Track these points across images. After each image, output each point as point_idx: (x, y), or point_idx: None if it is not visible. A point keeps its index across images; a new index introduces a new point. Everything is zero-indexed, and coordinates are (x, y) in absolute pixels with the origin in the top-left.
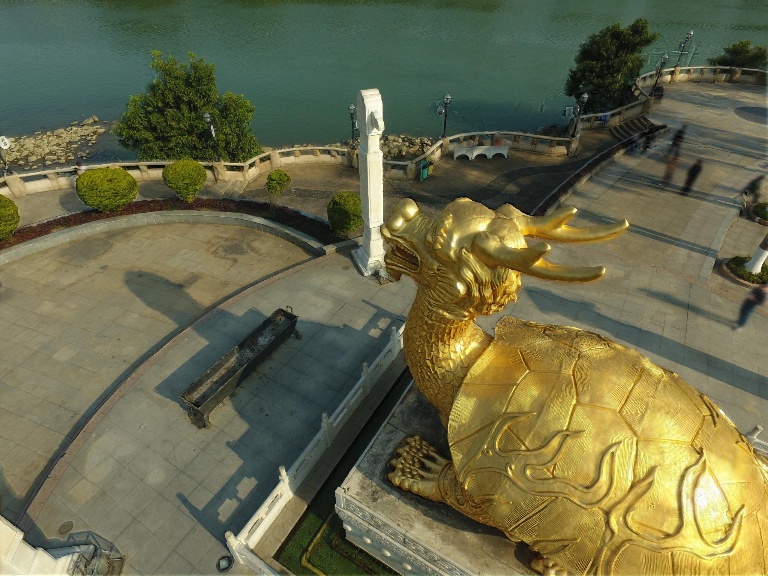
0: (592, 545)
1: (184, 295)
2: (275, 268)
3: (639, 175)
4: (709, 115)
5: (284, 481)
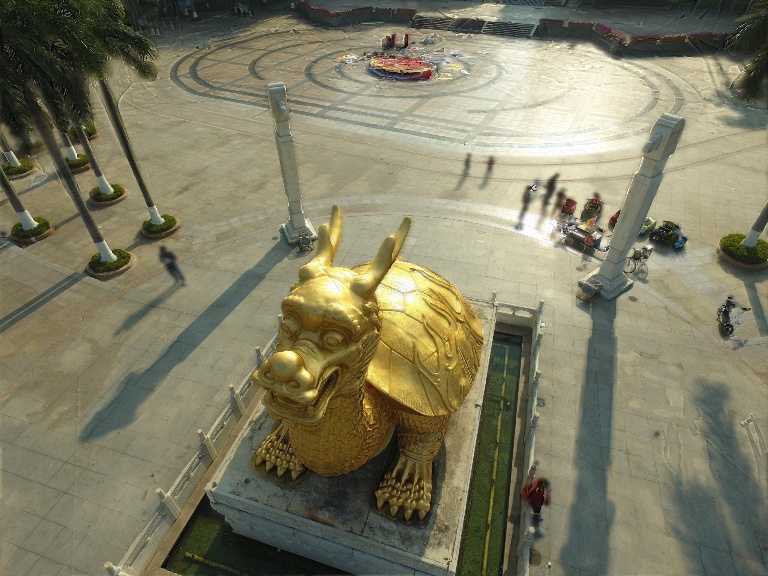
0: None
1: None
2: None
3: None
4: None
5: None
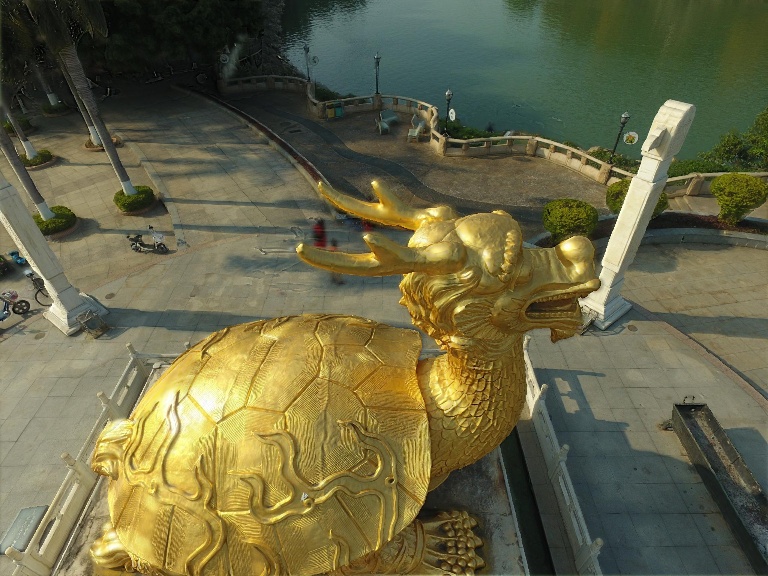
0: None
1: None
2: None
3: None
4: None
5: None
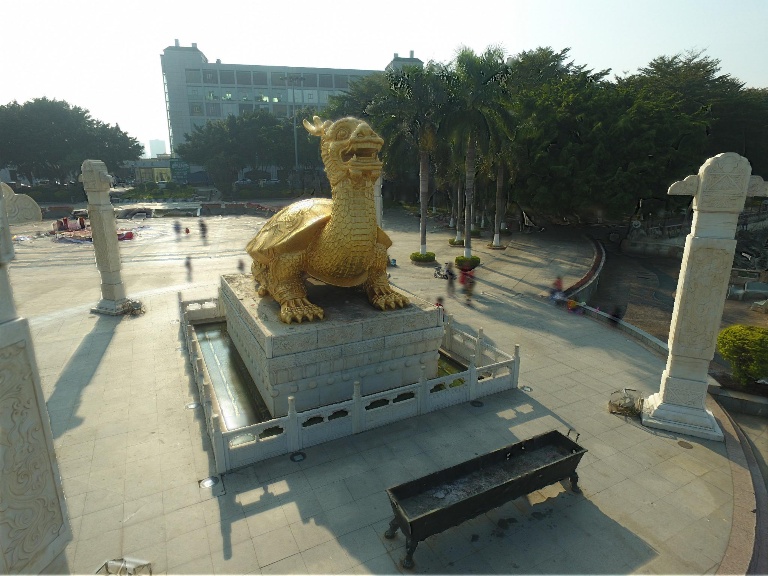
0: None
1: None
2: None
3: None
4: None
5: None
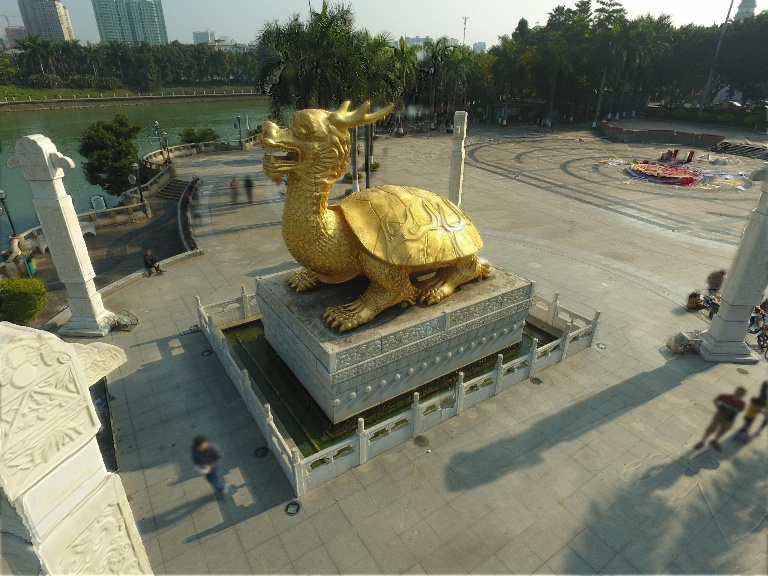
0: (449, 242)
1: None
2: None
3: (218, 205)
4: (213, 169)
5: (272, 419)
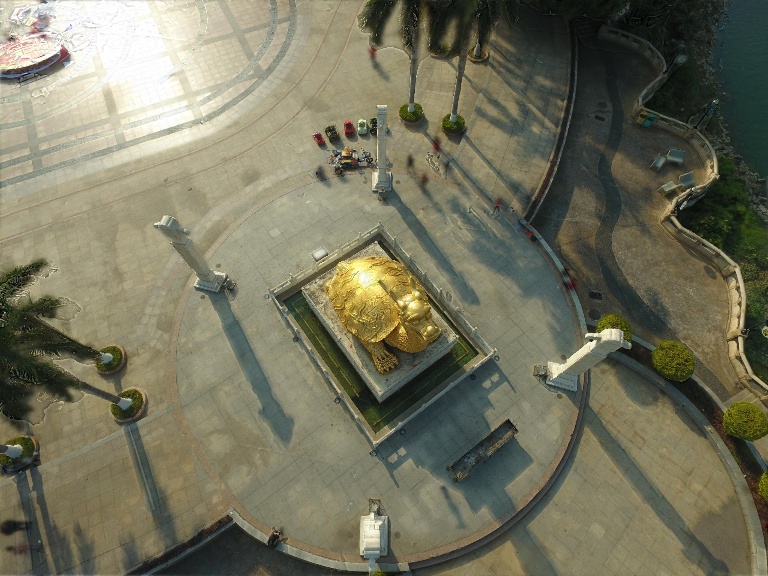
0: None
1: (525, 568)
2: (451, 575)
3: (33, 572)
4: None
5: None
